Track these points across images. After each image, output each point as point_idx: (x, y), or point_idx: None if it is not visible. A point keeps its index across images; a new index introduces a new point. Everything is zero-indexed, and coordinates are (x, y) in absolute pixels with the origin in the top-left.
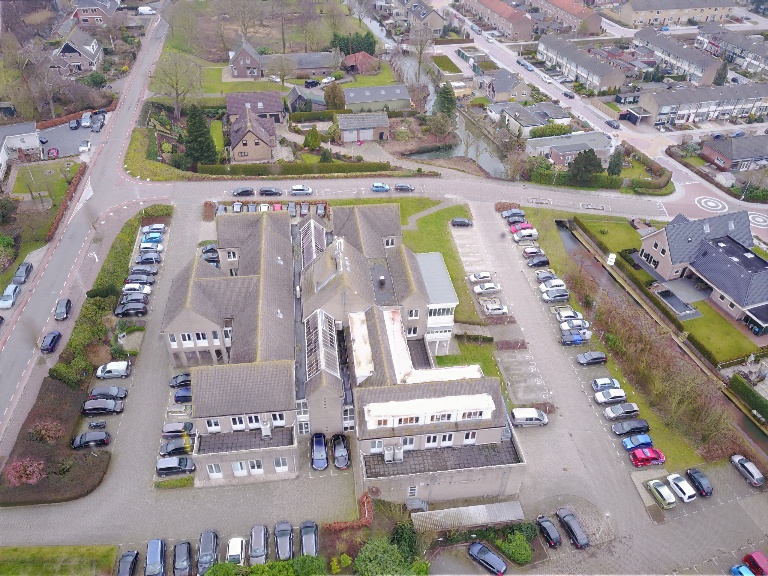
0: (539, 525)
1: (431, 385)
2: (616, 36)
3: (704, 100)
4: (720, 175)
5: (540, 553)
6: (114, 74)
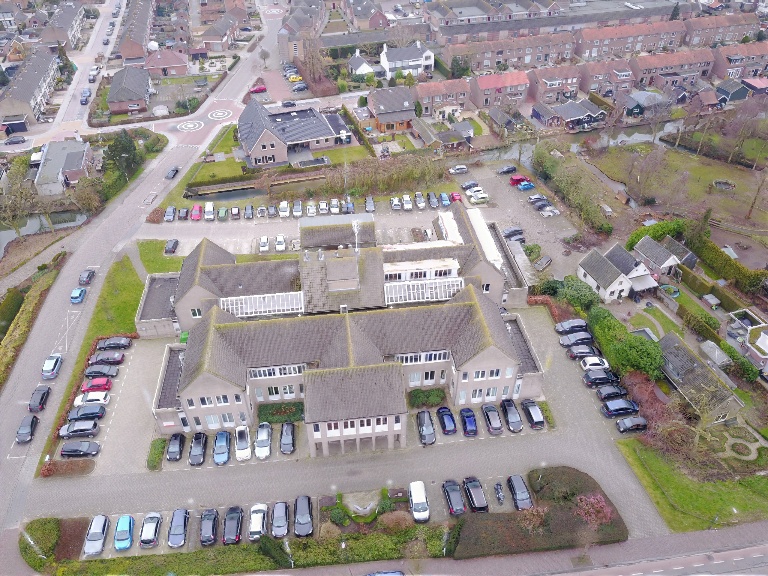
0: None
1: (470, 227)
2: None
3: (37, 82)
4: (158, 110)
5: None
6: None
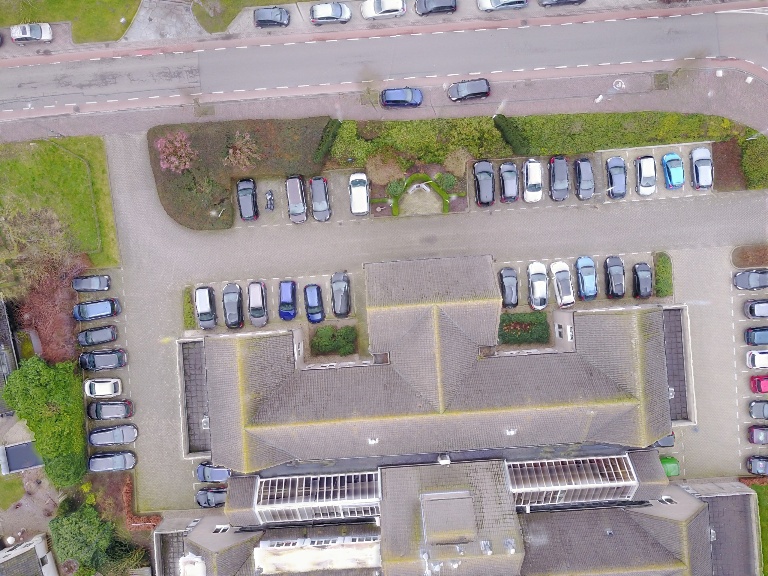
0: None
1: None
2: None
3: None
4: None
5: None
6: None
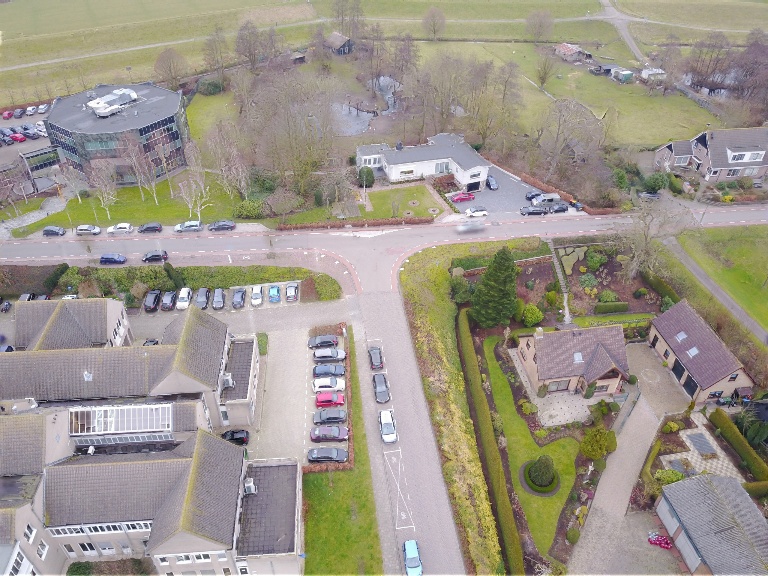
0: None
1: None
2: None
3: None
4: None
5: None
6: None
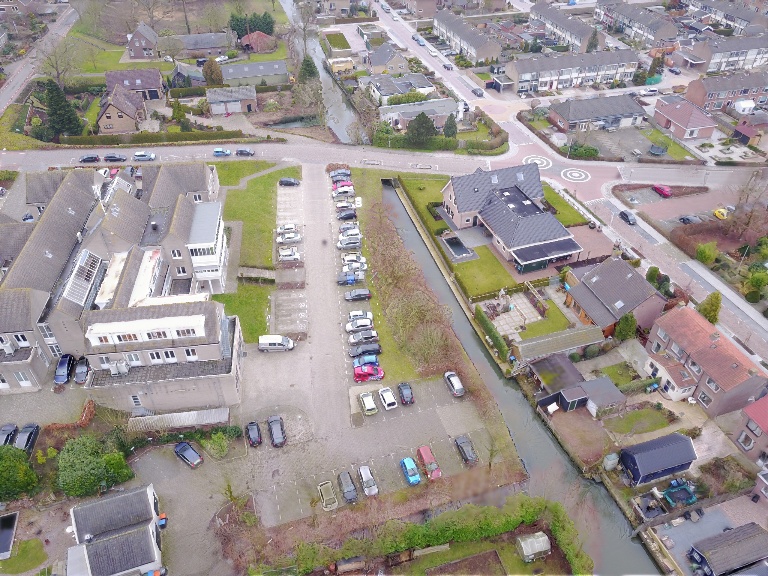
0: (246, 428)
1: (151, 307)
2: (521, 11)
3: (564, 67)
4: (554, 135)
5: (240, 451)
6: (11, 57)
